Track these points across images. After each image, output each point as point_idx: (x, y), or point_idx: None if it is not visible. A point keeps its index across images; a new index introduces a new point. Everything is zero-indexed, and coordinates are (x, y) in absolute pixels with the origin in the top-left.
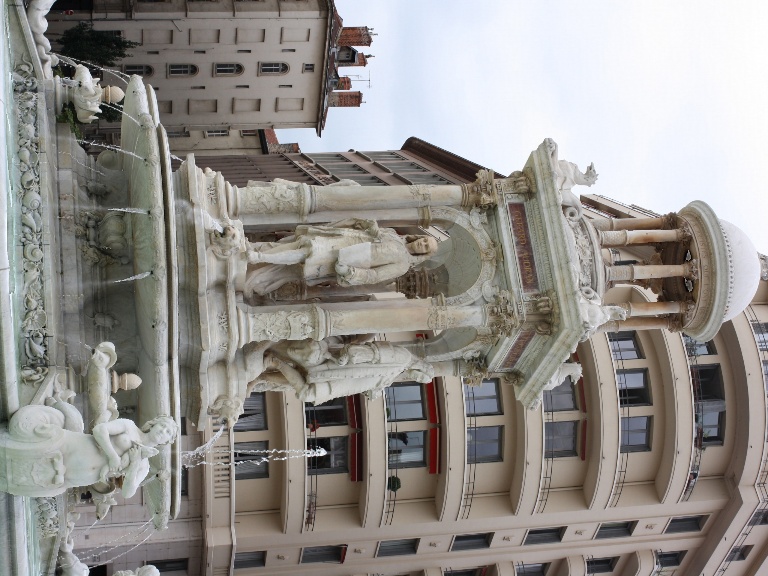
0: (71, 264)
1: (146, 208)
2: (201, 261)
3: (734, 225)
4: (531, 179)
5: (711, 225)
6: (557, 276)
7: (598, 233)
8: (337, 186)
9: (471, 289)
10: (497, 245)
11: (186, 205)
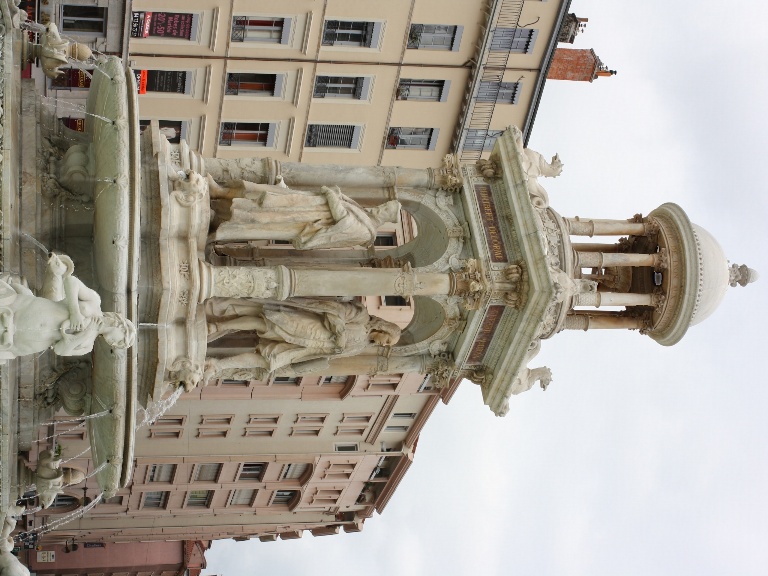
0: (28, 428)
1: (103, 482)
2: (156, 399)
3: (717, 284)
4: (522, 302)
5: (684, 314)
6: (499, 375)
7: (571, 306)
8: (321, 276)
9: (421, 343)
10: (463, 320)
11: (153, 319)
